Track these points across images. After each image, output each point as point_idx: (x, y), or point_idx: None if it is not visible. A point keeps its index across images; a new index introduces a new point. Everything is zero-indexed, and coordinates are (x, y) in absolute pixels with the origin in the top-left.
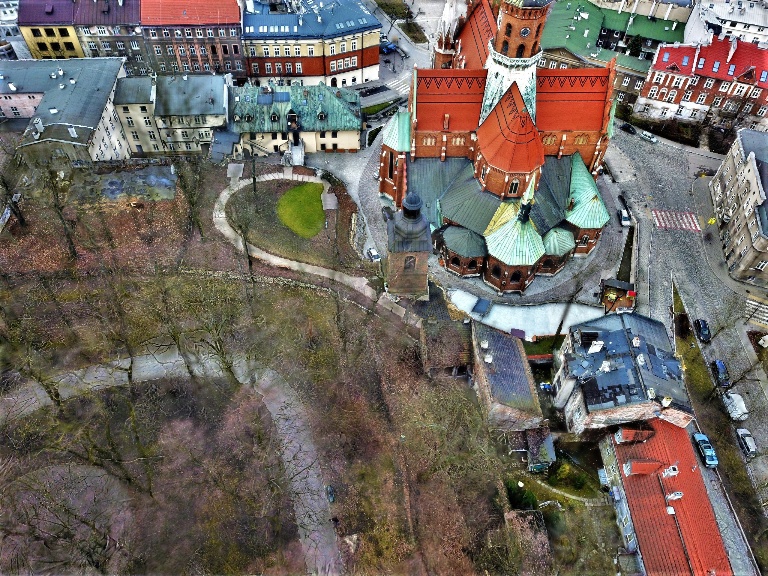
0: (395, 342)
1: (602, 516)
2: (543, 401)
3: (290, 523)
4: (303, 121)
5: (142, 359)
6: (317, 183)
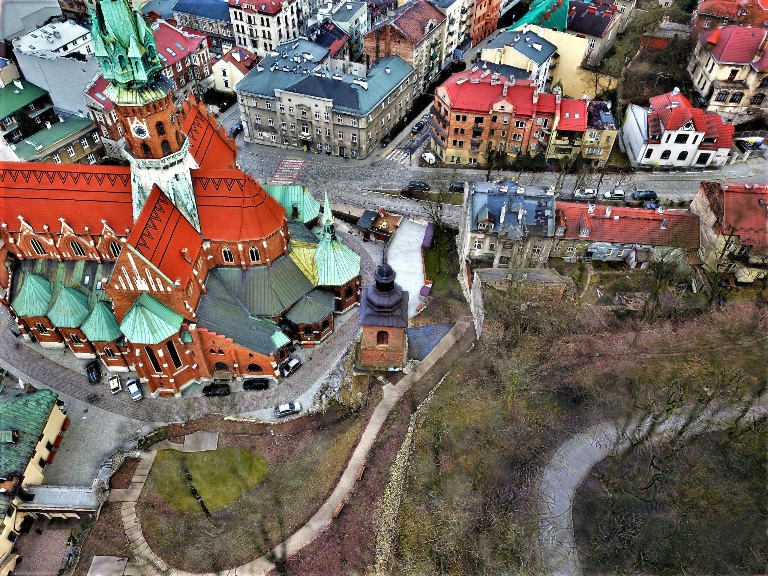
0: (479, 361)
1: (600, 268)
2: None
3: (712, 437)
4: (6, 468)
5: None
6: (156, 457)
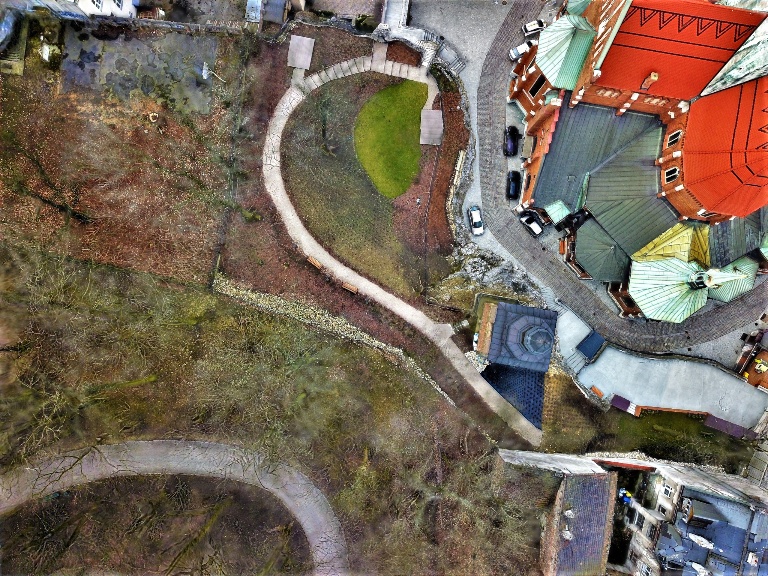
0: None
1: None
2: (615, 510)
3: None
4: None
5: (170, 446)
6: (420, 83)
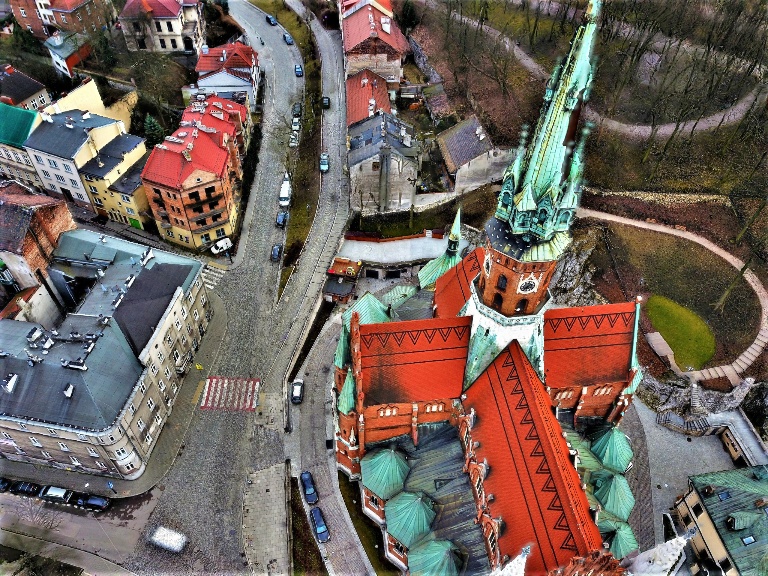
0: None
1: None
2: (425, 182)
3: None
4: None
5: None
6: None
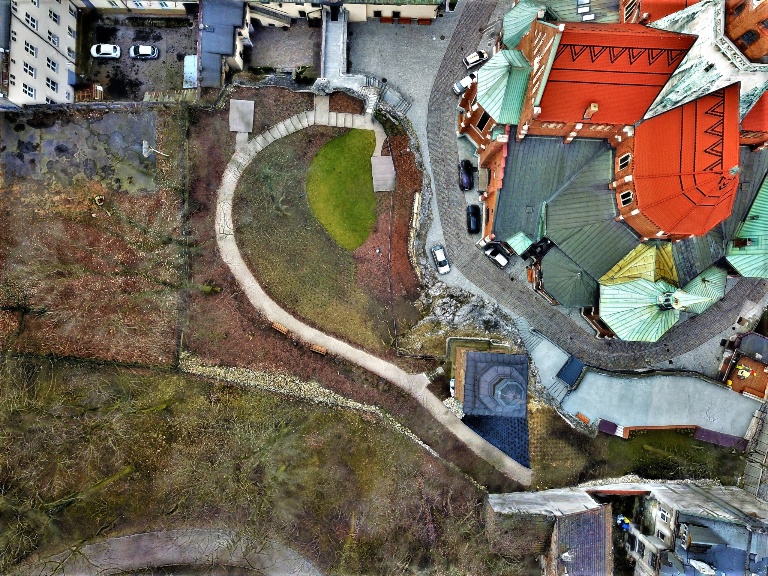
0: (455, 493)
1: None
2: (615, 538)
3: None
4: None
5: (152, 538)
6: (366, 131)
